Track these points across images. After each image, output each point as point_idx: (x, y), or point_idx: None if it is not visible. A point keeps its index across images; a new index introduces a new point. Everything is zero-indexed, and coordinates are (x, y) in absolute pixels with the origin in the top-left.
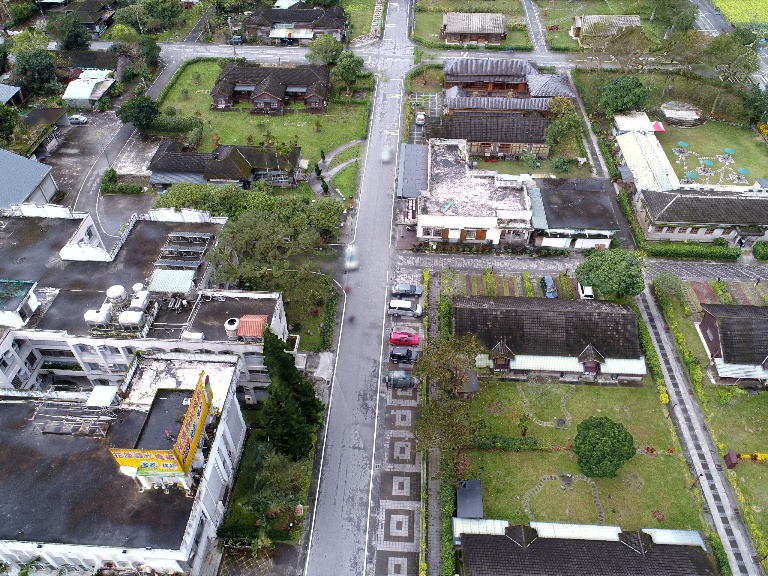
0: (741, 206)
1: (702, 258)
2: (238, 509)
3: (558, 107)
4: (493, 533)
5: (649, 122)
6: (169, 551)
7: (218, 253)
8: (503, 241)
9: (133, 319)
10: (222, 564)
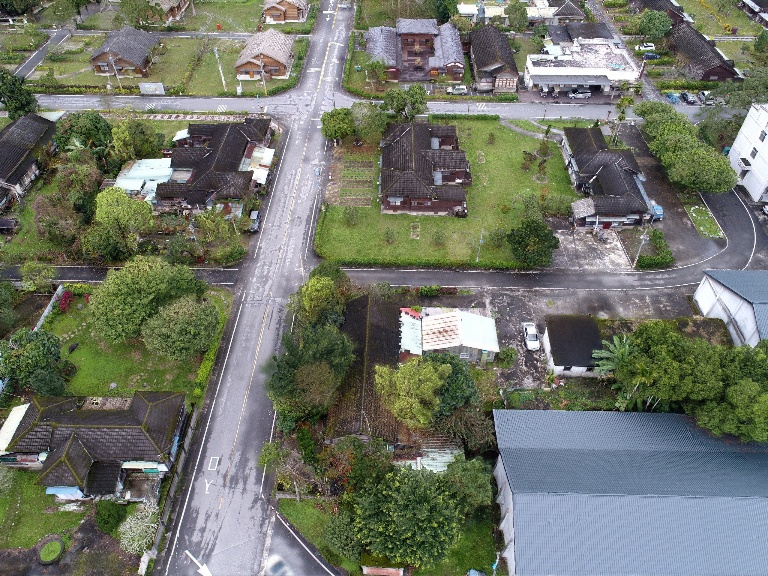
0: None
1: None
2: None
3: (463, 23)
4: None
5: None
6: None
7: None
8: None
9: None
10: None
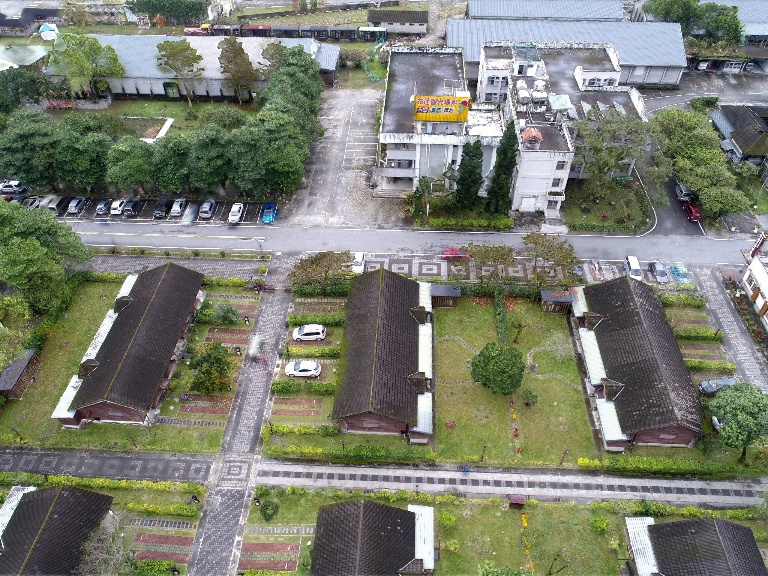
0: None
1: None
2: (433, 200)
3: None
4: (421, 301)
5: None
6: None
7: (592, 111)
8: None
9: (522, 94)
10: (401, 199)
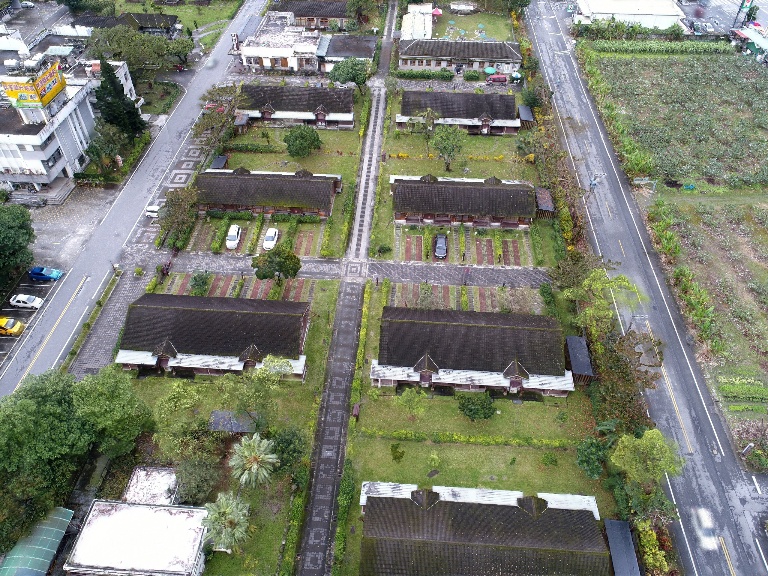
0: (457, 46)
1: (429, 79)
2: (90, 171)
3: None
4: None
5: (431, 8)
6: (31, 136)
7: (89, 39)
8: (301, 69)
9: (32, 63)
10: (75, 189)
